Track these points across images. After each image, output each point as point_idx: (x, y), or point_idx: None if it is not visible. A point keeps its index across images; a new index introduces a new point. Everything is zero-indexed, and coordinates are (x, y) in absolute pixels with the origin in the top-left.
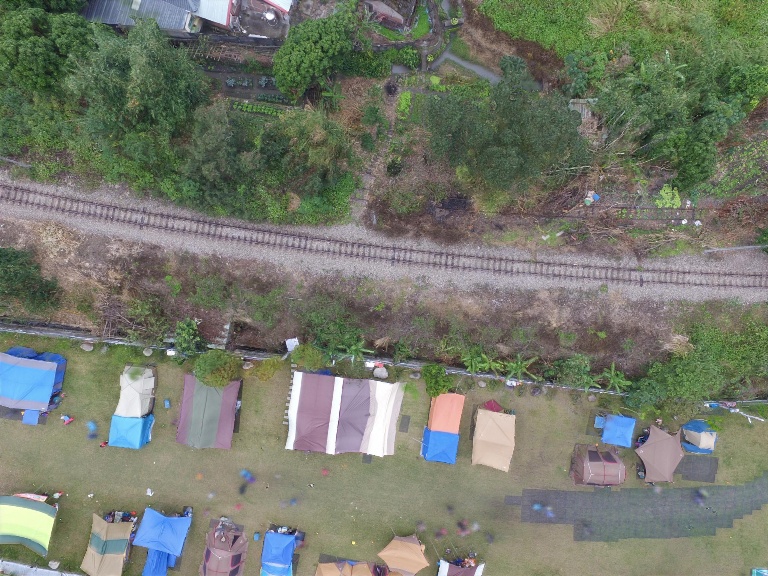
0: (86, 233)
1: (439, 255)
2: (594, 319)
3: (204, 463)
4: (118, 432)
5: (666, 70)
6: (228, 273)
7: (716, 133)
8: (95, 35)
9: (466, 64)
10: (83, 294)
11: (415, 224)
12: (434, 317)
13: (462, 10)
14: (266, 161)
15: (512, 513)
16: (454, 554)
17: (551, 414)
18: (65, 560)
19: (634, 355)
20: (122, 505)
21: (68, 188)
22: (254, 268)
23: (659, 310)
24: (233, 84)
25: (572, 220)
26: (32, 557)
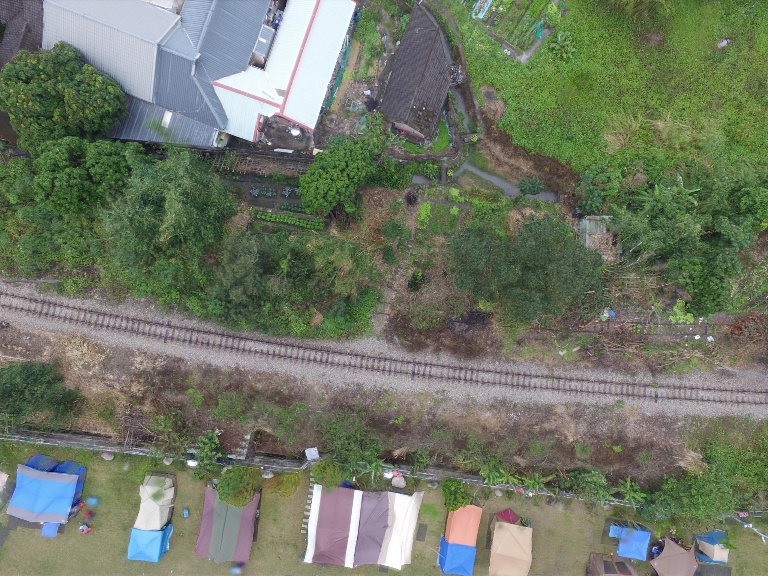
0: (111, 345)
1: (458, 370)
2: (610, 433)
3: (221, 572)
4: (138, 547)
5: (679, 193)
6: (250, 386)
7: (731, 270)
8: (128, 163)
9: (484, 175)
10: (105, 402)
11: (435, 339)
12: (453, 430)
13: (481, 125)
14: None
15: None
16: None
17: (567, 523)
18: None
19: (649, 467)
20: None
21: (94, 301)
22: (276, 381)
23: (673, 425)
24: (257, 194)
25: (588, 335)
26: None
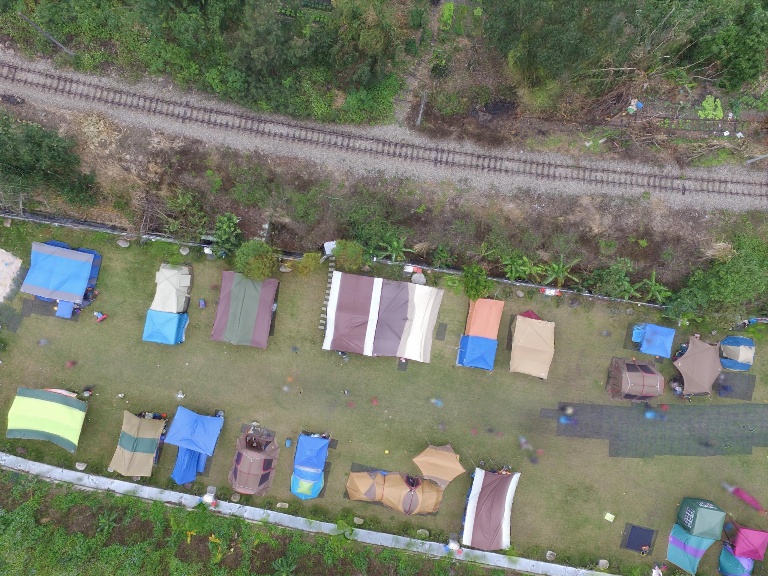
0: (128, 125)
1: (482, 158)
2: (635, 227)
3: (237, 366)
4: (154, 325)
5: None
6: (269, 170)
7: (767, 27)
8: None
9: None
10: (121, 191)
11: (458, 126)
12: (475, 221)
13: None
14: (314, 52)
15: (547, 426)
16: (488, 467)
17: (589, 326)
18: (92, 462)
19: (674, 266)
20: (153, 406)
21: (111, 79)
22: (296, 166)
23: (701, 219)
24: None
25: (615, 128)
26: (59, 457)
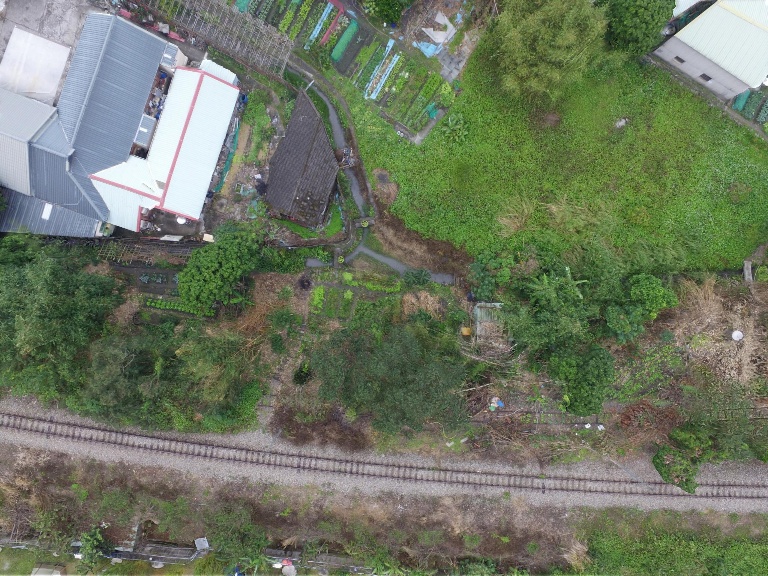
0: None
1: (344, 462)
2: (497, 524)
3: None
4: None
5: (567, 284)
6: (135, 480)
7: (602, 376)
8: None
9: (380, 257)
10: None
11: (320, 432)
12: (340, 522)
13: (374, 209)
14: None
15: None
16: None
17: None
18: None
19: (538, 556)
20: None
21: None
22: (161, 475)
23: (561, 516)
24: (147, 281)
25: (477, 425)
26: None
